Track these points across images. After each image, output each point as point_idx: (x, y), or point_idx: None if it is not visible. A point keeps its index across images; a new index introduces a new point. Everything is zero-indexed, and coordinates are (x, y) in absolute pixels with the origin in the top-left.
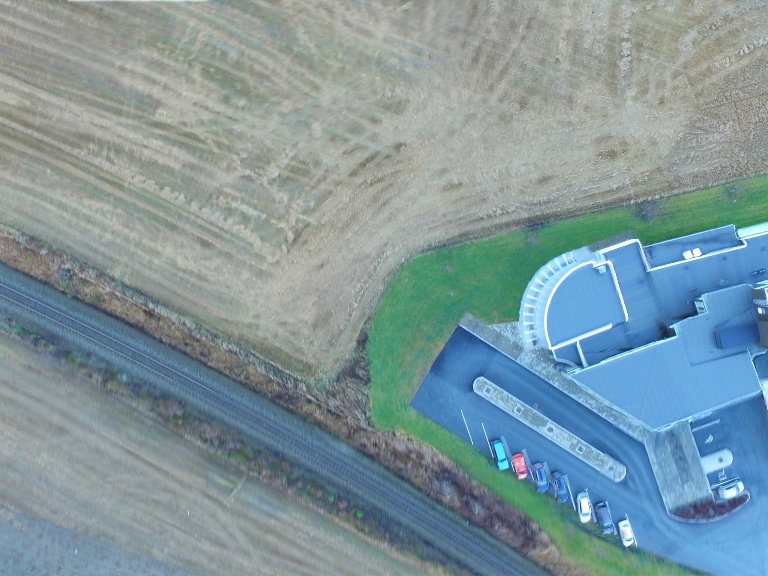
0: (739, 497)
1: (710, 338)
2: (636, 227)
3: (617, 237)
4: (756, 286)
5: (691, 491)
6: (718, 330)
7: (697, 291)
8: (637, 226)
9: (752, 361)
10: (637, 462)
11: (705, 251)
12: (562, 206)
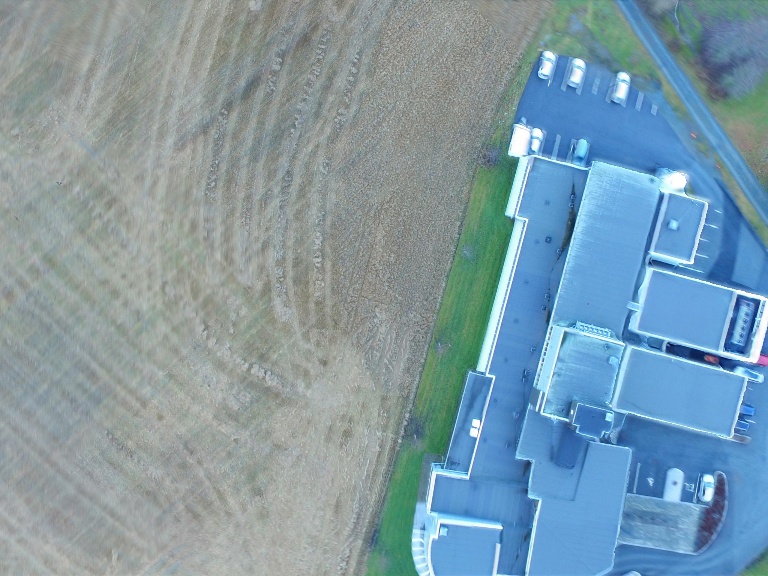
0: (717, 483)
1: (559, 469)
2: (424, 449)
3: (424, 471)
4: (535, 406)
5: (688, 524)
6: (555, 459)
7: (511, 441)
8: (424, 447)
9: (600, 443)
10: (635, 558)
11: (479, 417)
12: (369, 505)
